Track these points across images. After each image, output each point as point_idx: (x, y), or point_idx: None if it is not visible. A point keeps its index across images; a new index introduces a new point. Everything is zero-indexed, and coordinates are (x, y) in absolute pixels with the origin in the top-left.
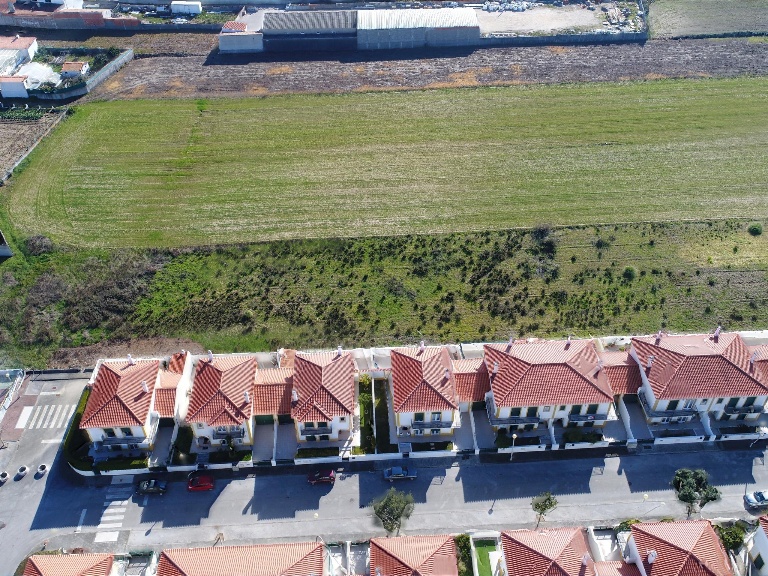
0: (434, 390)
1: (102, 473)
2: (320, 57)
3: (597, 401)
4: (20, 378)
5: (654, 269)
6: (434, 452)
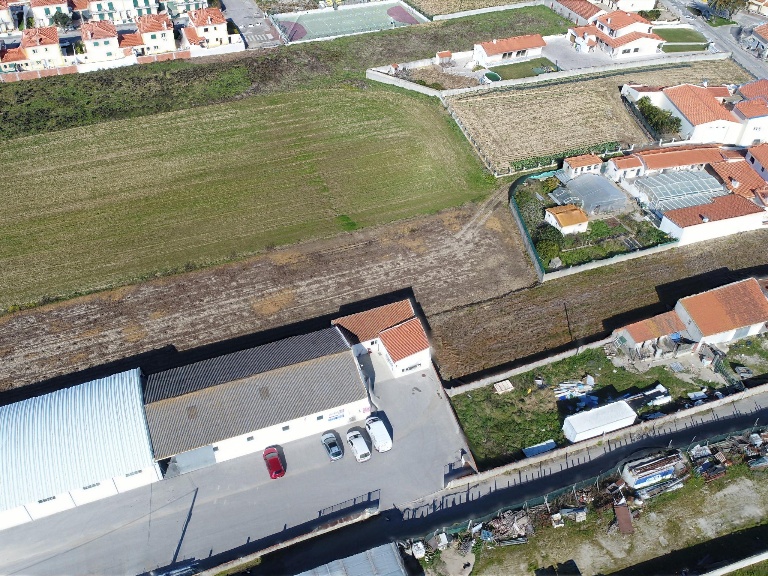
0: None
1: None
2: (220, 354)
3: None
4: None
5: None
6: None
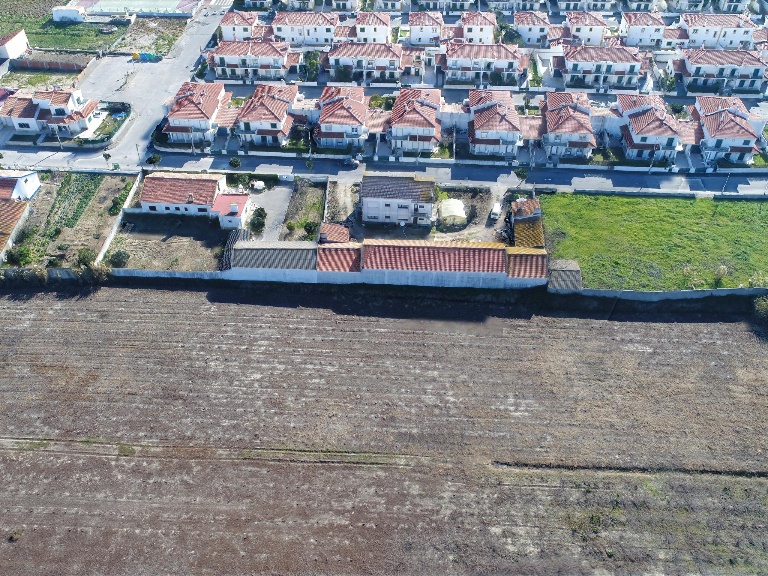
0: None
1: None
2: None
3: None
4: None
5: None
6: (391, 12)
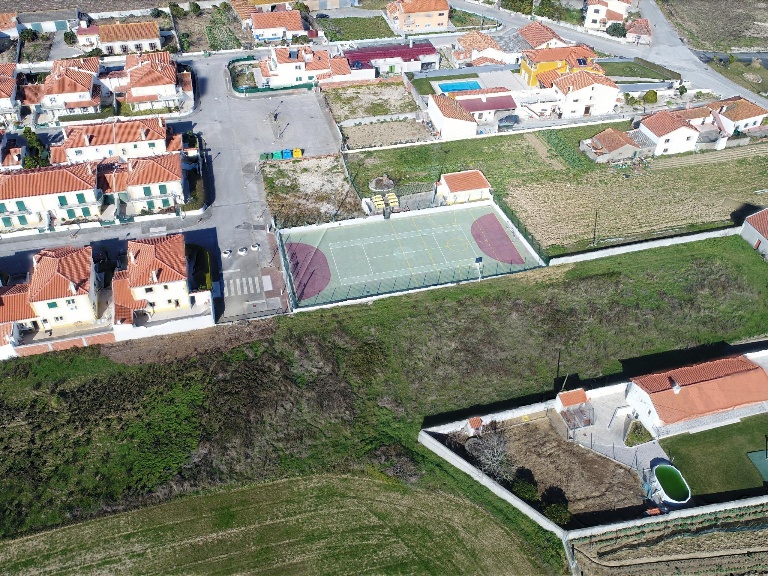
0: None
1: None
2: None
3: None
4: None
5: None
6: None
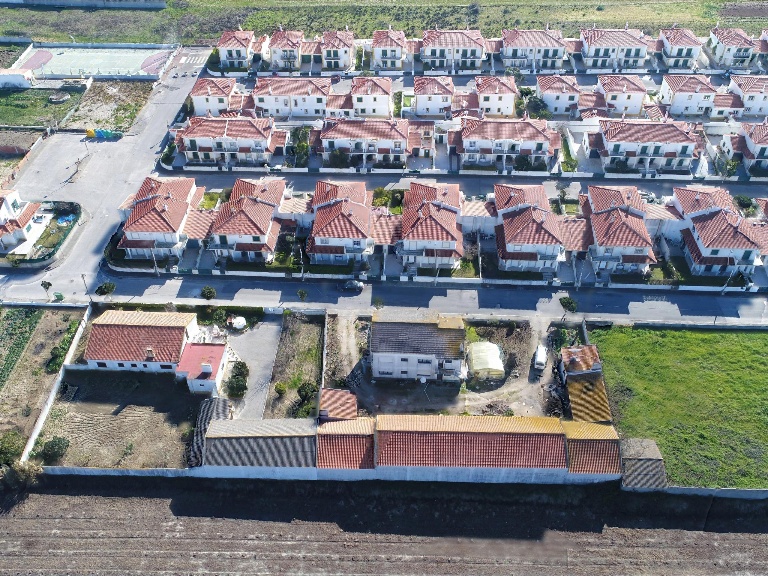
0: (393, 40)
1: (225, 74)
2: None
3: (475, 46)
4: (179, 47)
5: (533, 21)
6: (391, 71)
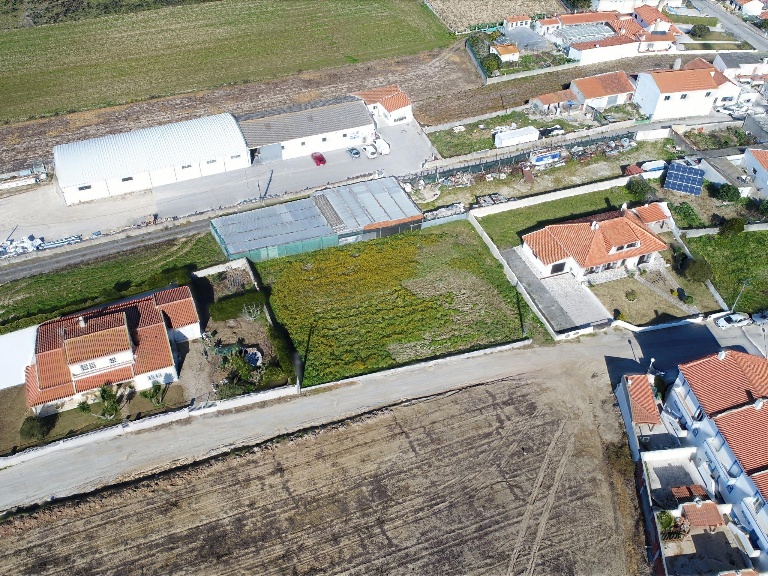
0: None
1: None
2: None
3: None
4: None
5: None
6: None
